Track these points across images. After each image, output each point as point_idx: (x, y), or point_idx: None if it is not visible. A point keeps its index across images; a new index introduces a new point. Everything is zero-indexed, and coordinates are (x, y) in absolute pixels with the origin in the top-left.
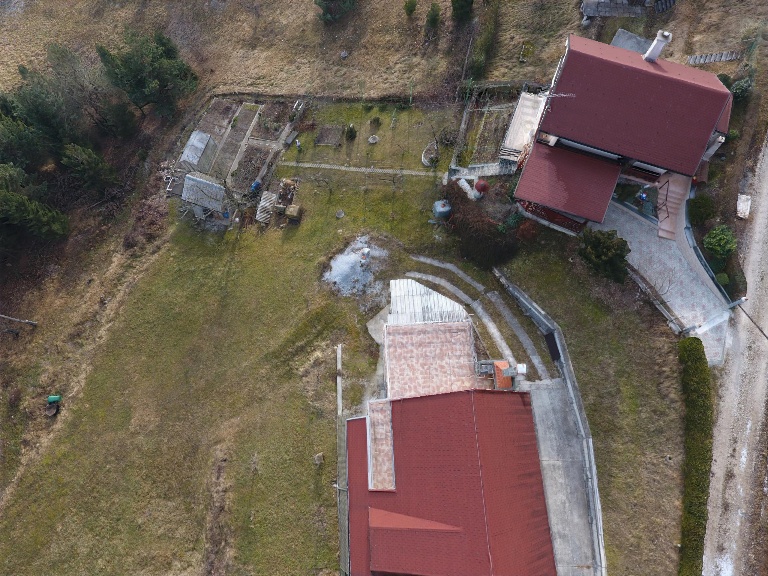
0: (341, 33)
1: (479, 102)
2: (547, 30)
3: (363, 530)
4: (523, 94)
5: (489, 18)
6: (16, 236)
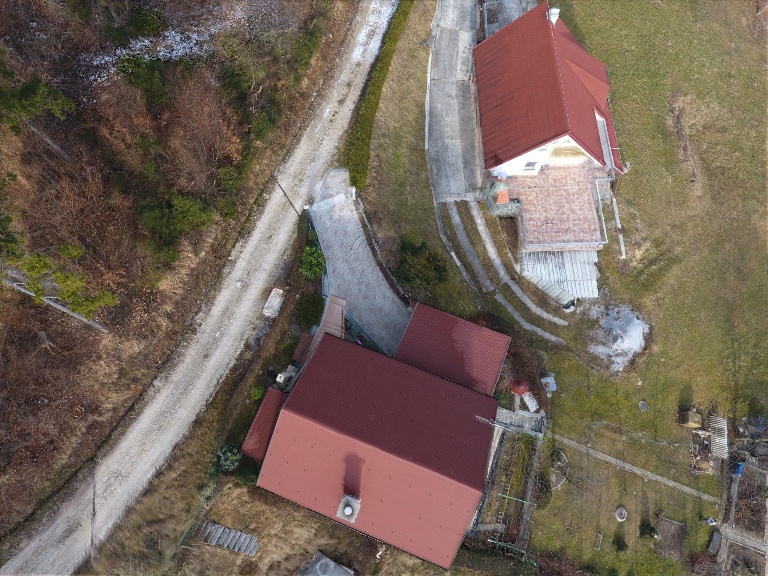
0: None
1: None
2: None
3: None
4: None
5: None
6: None
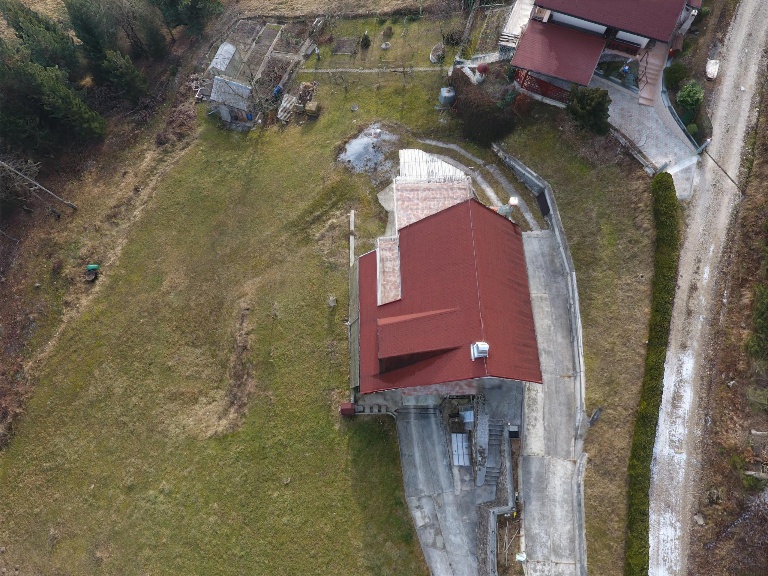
0: None
1: (483, 7)
2: None
3: (372, 339)
4: None
5: None
6: (58, 135)
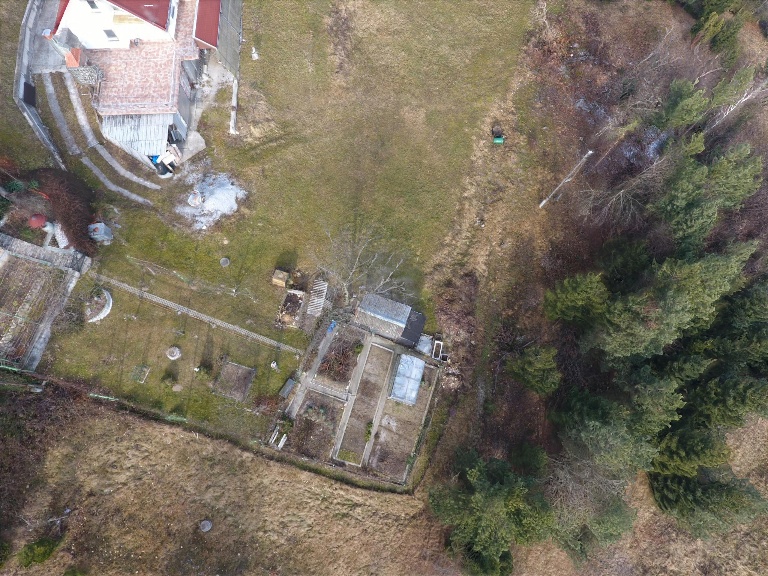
0: None
1: None
2: None
3: None
4: None
5: None
6: None
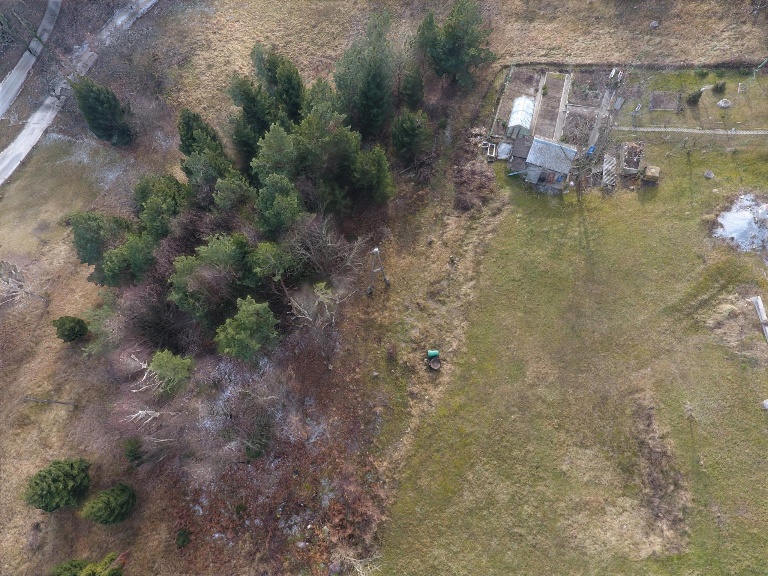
0: (642, 4)
1: None
2: None
3: None
4: None
5: None
6: None
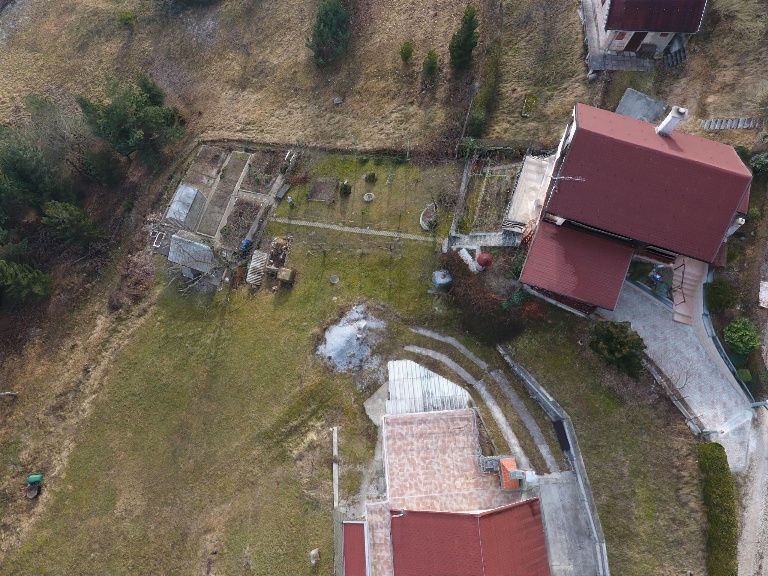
0: (334, 77)
1: (480, 161)
2: (550, 82)
3: None
4: (527, 158)
5: (489, 70)
6: None
